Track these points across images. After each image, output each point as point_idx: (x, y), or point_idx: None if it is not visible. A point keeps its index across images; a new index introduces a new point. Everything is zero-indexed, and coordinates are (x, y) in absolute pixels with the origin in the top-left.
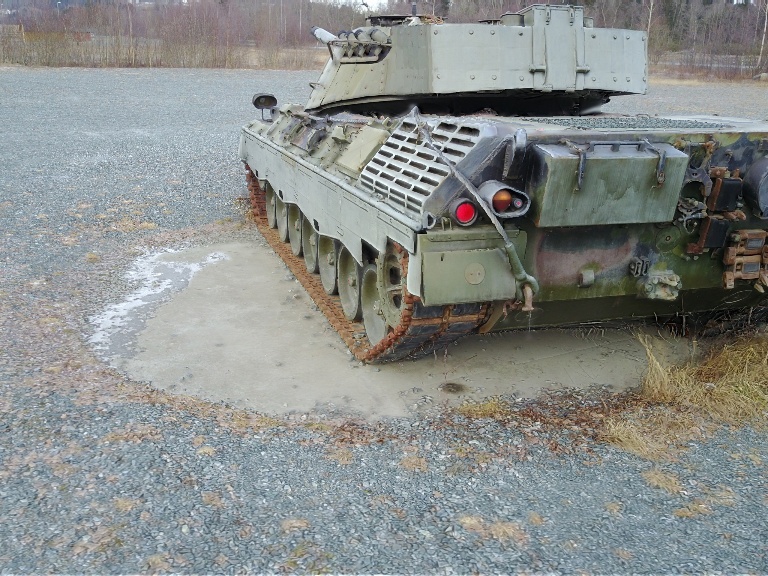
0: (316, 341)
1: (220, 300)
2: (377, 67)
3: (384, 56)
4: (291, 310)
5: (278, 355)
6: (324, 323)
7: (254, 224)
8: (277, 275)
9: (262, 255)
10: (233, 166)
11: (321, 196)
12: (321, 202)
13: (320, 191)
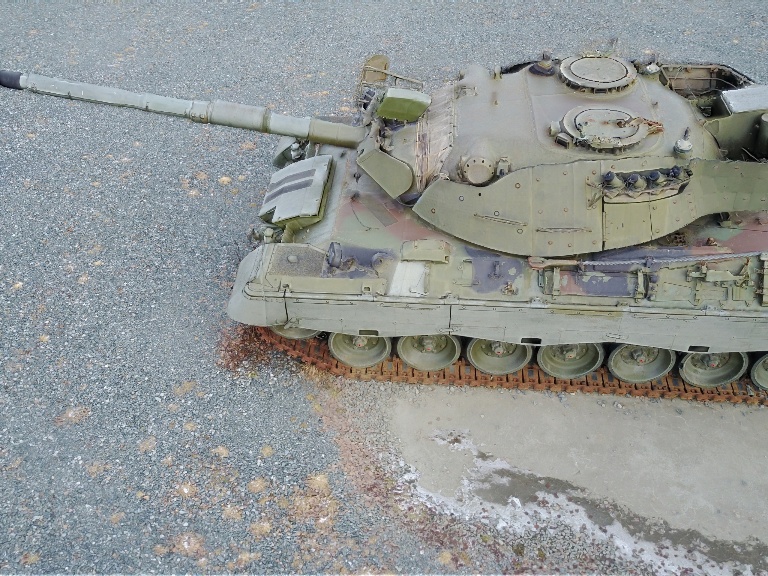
0: (735, 419)
1: (618, 462)
2: (681, 199)
3: (684, 187)
4: (656, 417)
5: (766, 449)
6: (694, 404)
7: (330, 378)
8: (544, 404)
9: (459, 399)
10: None
11: (731, 330)
12: (729, 334)
13: (728, 327)
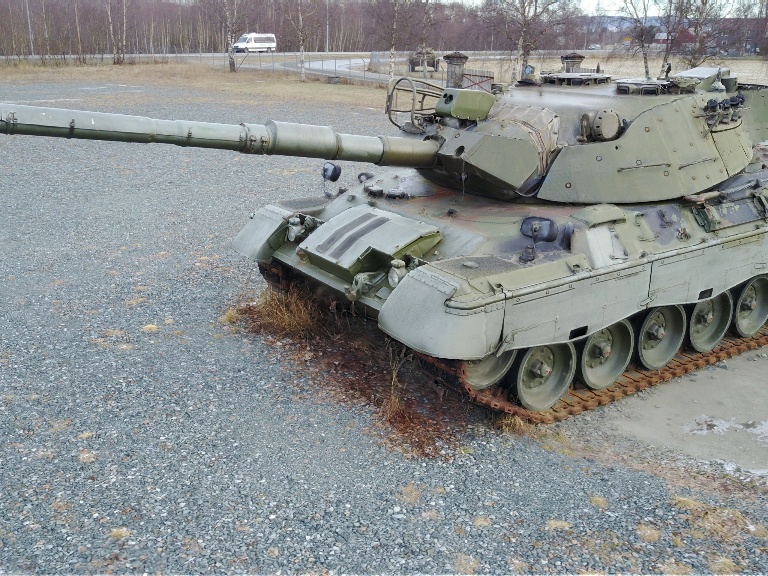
0: None
1: None
2: None
3: None
4: None
5: None
6: None
7: (533, 429)
8: (719, 375)
9: (659, 399)
10: (1, 560)
11: None
12: None
13: None
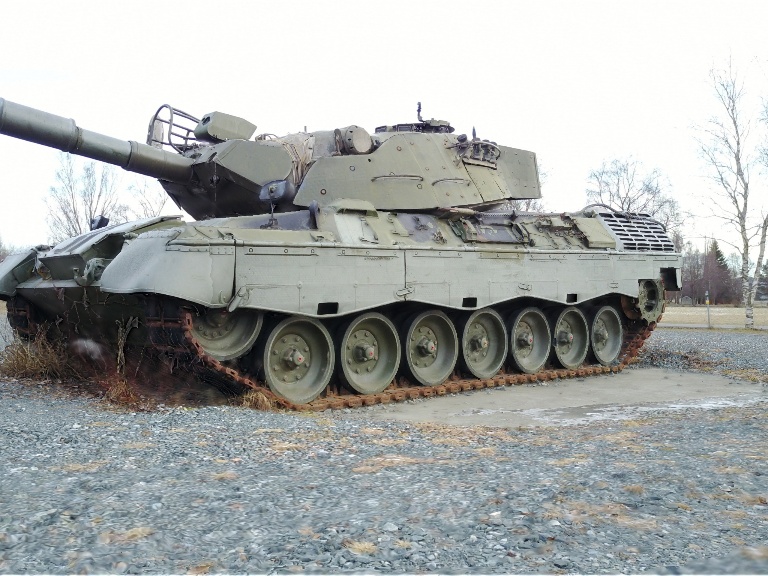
0: (613, 378)
1: None
2: None
3: None
4: (575, 384)
5: None
6: None
7: None
8: (496, 393)
9: (429, 404)
10: None
11: None
12: None
13: None
